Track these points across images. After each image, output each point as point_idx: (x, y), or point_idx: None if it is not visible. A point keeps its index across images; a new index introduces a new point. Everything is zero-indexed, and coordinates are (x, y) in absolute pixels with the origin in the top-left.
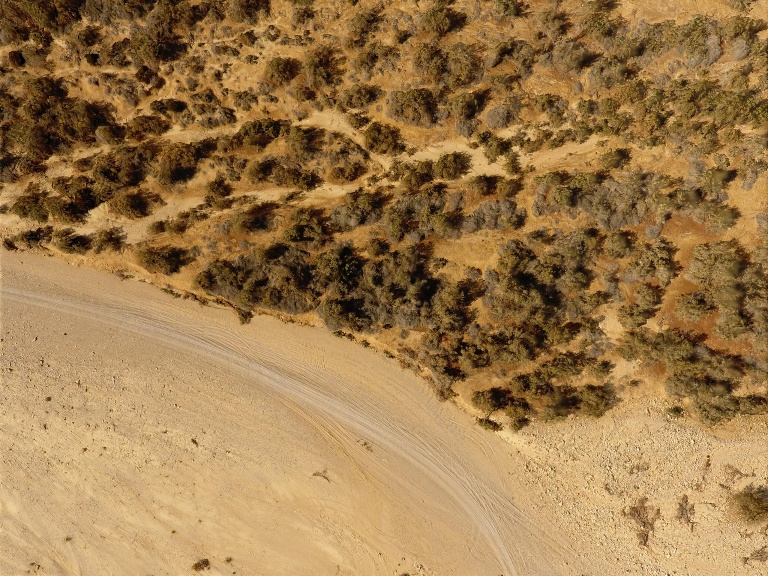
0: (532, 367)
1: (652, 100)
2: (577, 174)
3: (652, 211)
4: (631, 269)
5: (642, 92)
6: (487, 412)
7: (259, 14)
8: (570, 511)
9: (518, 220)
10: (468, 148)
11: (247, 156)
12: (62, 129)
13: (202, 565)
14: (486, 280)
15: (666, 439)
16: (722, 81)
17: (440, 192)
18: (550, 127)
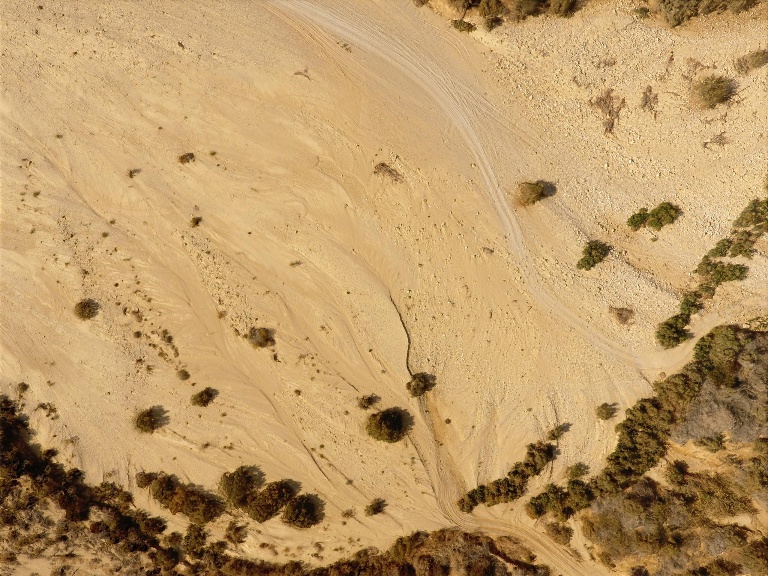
0: None
1: None
2: None
3: None
4: None
5: None
6: (461, 10)
7: None
8: (540, 104)
9: None
10: None
11: None
12: None
13: (187, 156)
14: None
15: (632, 37)
16: None
17: None
18: None
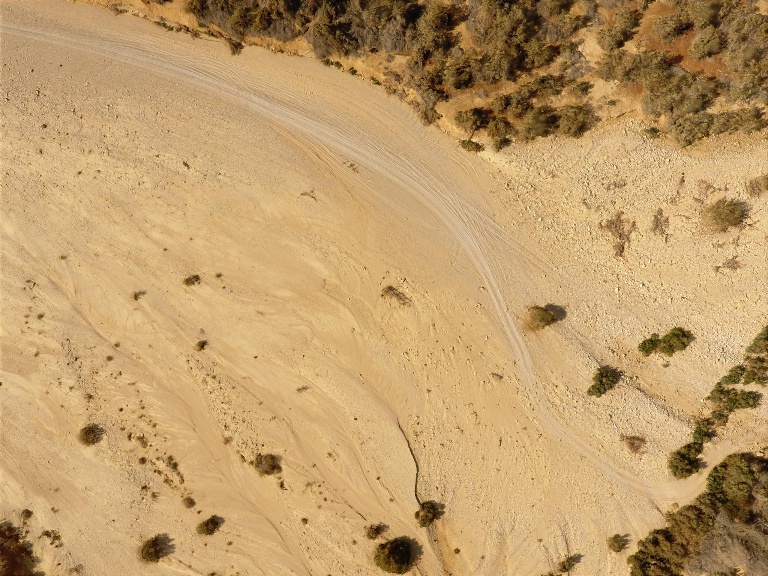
0: (513, 88)
1: None
2: None
3: None
4: None
5: None
6: (469, 131)
7: None
8: (549, 226)
9: None
10: None
11: None
12: None
13: (193, 279)
14: (470, 5)
15: (642, 158)
16: None
17: None
18: None
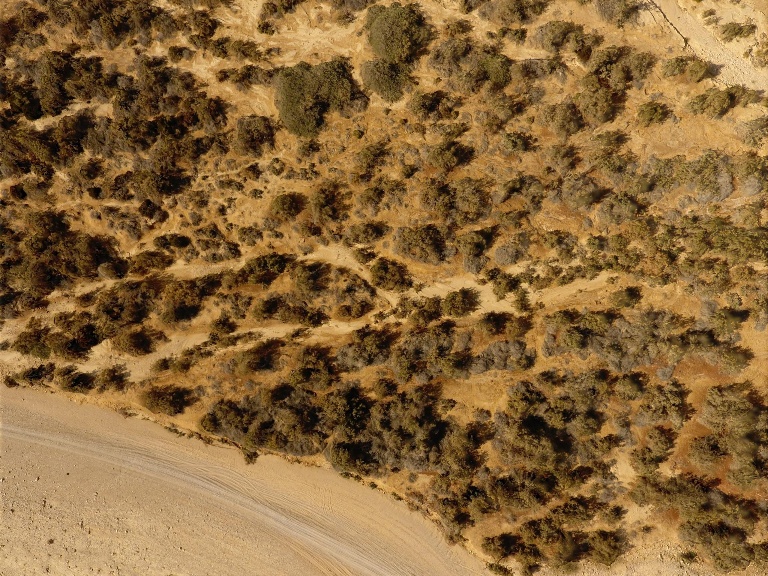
0: (543, 512)
1: (663, 239)
2: (587, 313)
3: (664, 353)
4: (643, 413)
5: (653, 228)
6: (497, 558)
7: (264, 147)
8: None
9: (528, 362)
10: (476, 284)
11: (252, 293)
12: (64, 268)
13: None
14: (495, 423)
15: None
16: (734, 218)
17: (448, 332)
18: (559, 263)
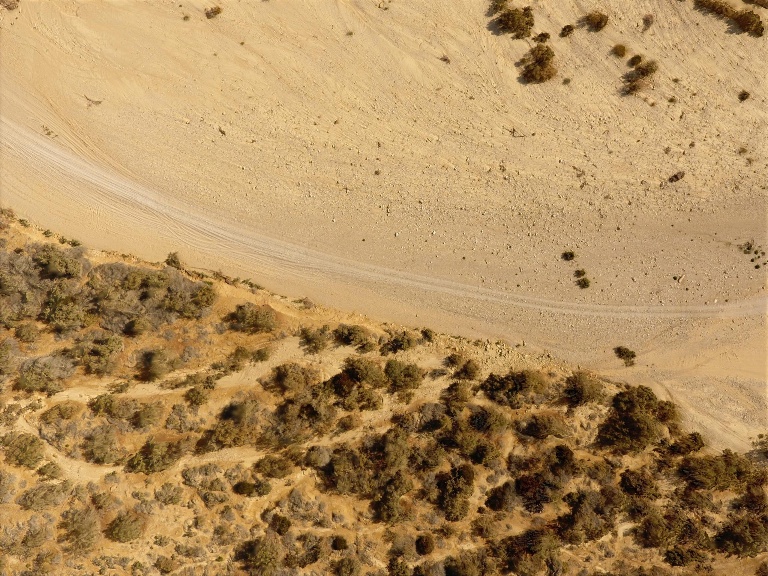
0: None
1: None
2: None
3: None
4: None
5: None
6: None
7: None
8: None
9: None
10: None
11: (166, 432)
12: (361, 463)
13: (211, 12)
14: None
15: None
16: None
17: None
18: None
